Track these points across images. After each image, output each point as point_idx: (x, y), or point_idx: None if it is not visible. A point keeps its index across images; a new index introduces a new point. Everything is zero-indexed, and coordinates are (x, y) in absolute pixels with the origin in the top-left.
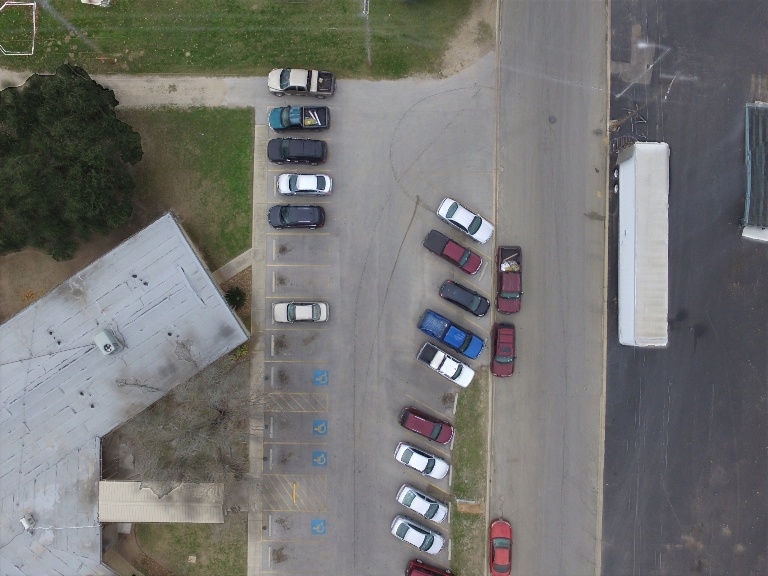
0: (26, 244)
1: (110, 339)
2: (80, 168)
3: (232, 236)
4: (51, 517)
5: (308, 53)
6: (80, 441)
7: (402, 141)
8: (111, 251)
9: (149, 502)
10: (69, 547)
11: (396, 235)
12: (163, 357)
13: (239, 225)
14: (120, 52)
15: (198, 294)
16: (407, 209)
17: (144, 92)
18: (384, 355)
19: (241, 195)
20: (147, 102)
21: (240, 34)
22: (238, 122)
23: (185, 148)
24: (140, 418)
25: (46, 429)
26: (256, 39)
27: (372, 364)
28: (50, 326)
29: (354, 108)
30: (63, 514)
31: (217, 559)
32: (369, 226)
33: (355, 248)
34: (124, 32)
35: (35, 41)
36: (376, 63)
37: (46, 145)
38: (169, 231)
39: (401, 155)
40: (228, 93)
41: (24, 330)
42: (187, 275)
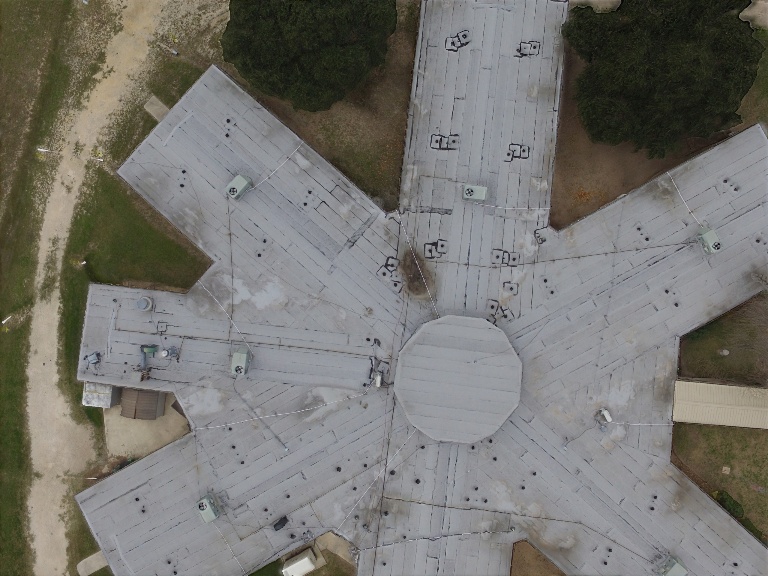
0: (632, 137)
1: (718, 238)
2: None
3: None
4: (624, 413)
5: None
6: (660, 339)
7: None
8: (702, 154)
9: (726, 405)
10: (640, 444)
11: None
12: (747, 263)
13: None
14: None
15: None
16: None
17: None
18: None
19: None
20: None
21: None
22: None
23: None
24: (727, 320)
25: (626, 324)
26: None
27: None
28: (636, 222)
29: None
30: (637, 411)
31: (750, 472)
32: None
33: None
34: None
35: None
36: None
37: (713, 36)
38: (759, 141)
39: None
40: None
41: (610, 224)
42: None
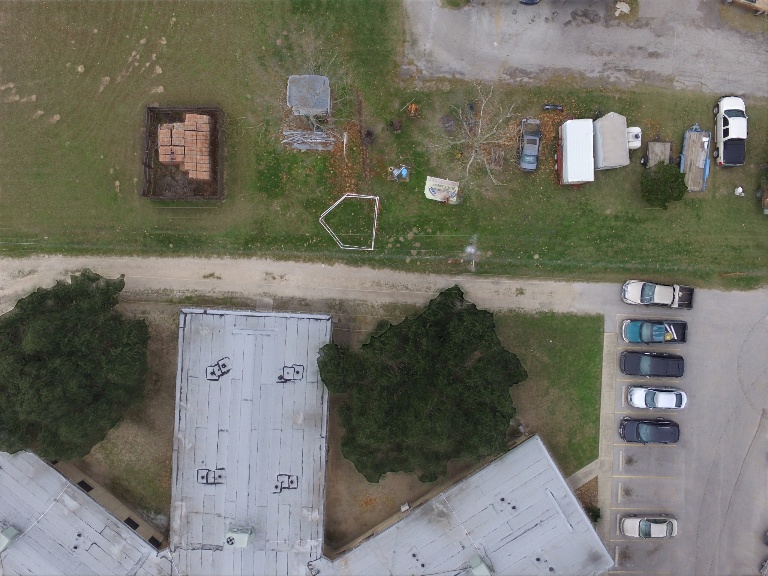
0: (398, 469)
1: None
2: (490, 414)
3: (579, 446)
4: None
5: (660, 260)
6: None
7: (750, 353)
8: (477, 472)
9: None
10: None
11: (741, 447)
12: None
13: (586, 435)
14: (466, 252)
15: (568, 520)
16: (752, 422)
17: (490, 294)
18: (724, 566)
19: (589, 405)
20: (493, 305)
21: (591, 238)
22: (587, 329)
23: (532, 354)
24: None
25: None
26: (608, 244)
27: (712, 575)
28: (412, 547)
29: (704, 319)
30: None
31: None
32: (715, 438)
33: (700, 460)
34: (471, 231)
35: (375, 236)
36: (728, 273)
37: (457, 390)
38: (537, 453)
39: (749, 367)
40: (577, 299)
41: (384, 551)
42: (557, 500)
